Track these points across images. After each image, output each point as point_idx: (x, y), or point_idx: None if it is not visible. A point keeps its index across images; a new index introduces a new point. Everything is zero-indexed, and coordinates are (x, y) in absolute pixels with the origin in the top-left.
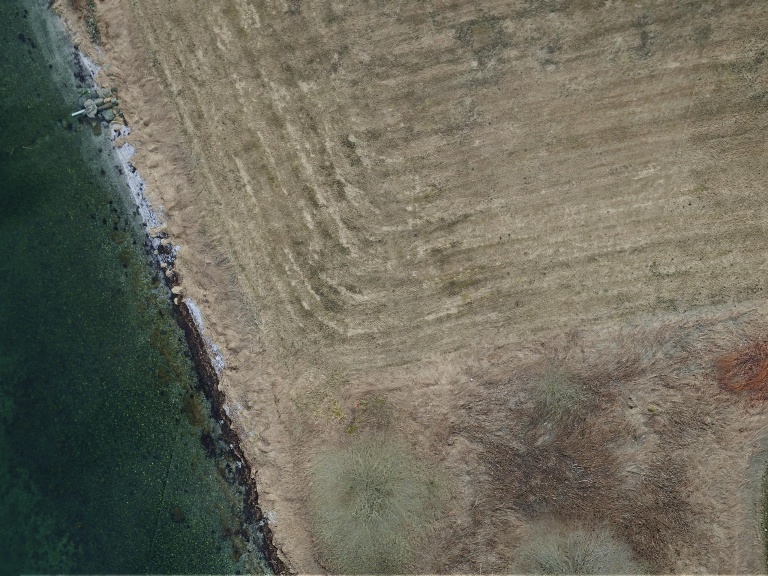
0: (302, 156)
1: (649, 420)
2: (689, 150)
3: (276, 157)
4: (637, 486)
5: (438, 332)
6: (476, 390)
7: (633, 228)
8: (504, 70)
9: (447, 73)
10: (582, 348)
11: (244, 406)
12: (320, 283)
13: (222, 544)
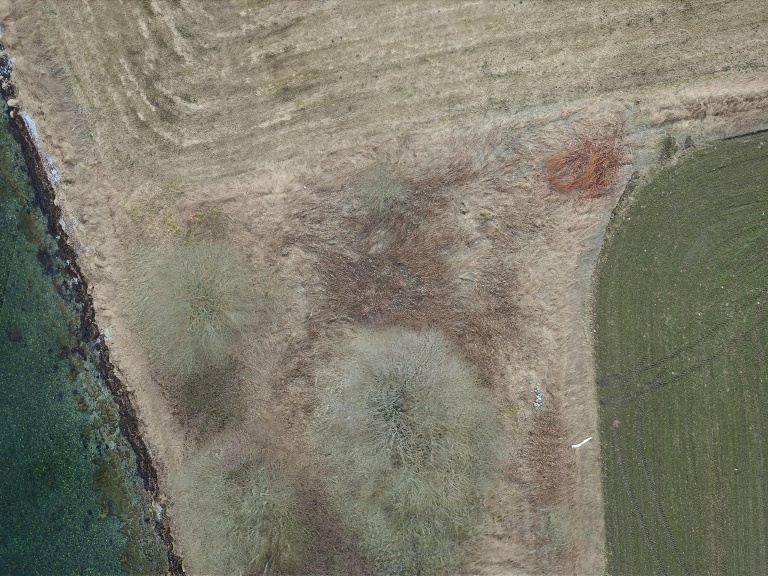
0: None
1: (482, 225)
2: None
3: None
4: (470, 293)
5: (272, 140)
6: (309, 198)
7: (464, 28)
8: None
9: None
10: (414, 152)
11: (80, 220)
12: (155, 93)
13: (59, 363)
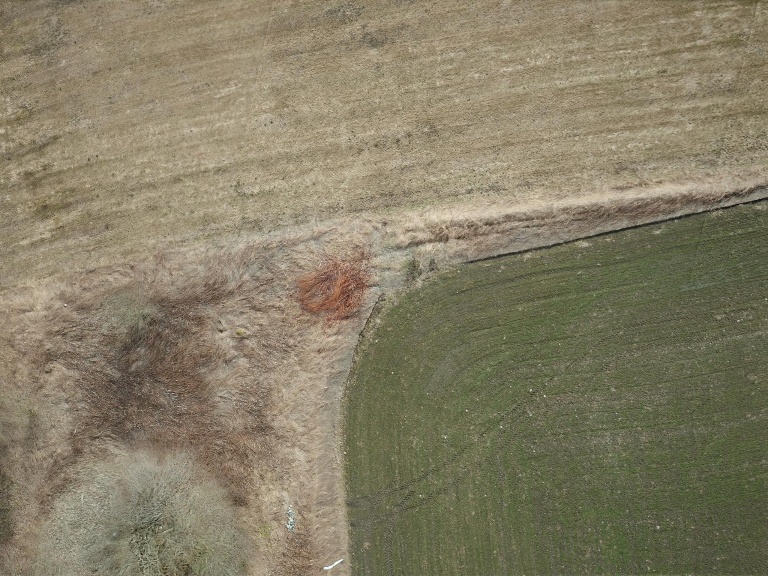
0: None
1: (238, 344)
2: (269, 67)
3: None
4: (228, 411)
5: (33, 257)
6: (70, 316)
7: (216, 147)
8: None
9: None
10: (170, 271)
11: None
12: None
13: None
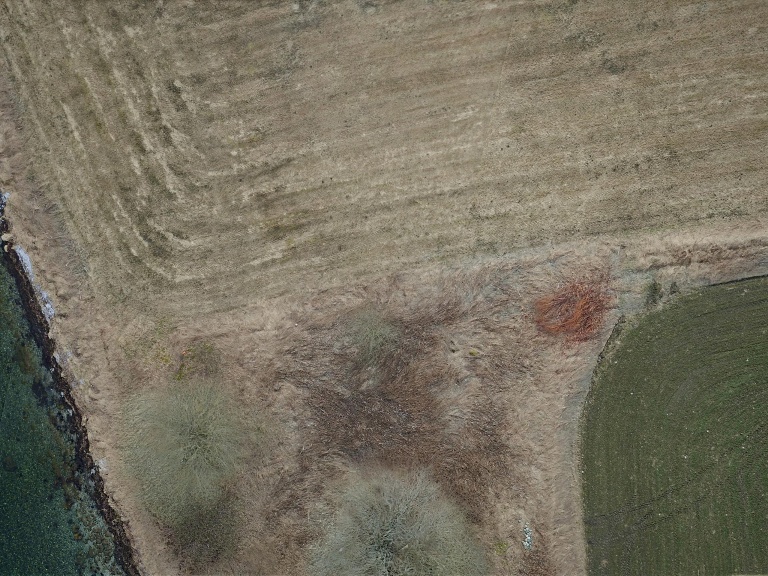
0: (129, 102)
1: (471, 364)
2: (507, 92)
3: (103, 103)
4: (460, 430)
5: (263, 277)
6: (301, 335)
7: (452, 170)
8: (325, 13)
9: (269, 17)
10: (404, 292)
11: (74, 353)
12: (148, 229)
13: (54, 493)
